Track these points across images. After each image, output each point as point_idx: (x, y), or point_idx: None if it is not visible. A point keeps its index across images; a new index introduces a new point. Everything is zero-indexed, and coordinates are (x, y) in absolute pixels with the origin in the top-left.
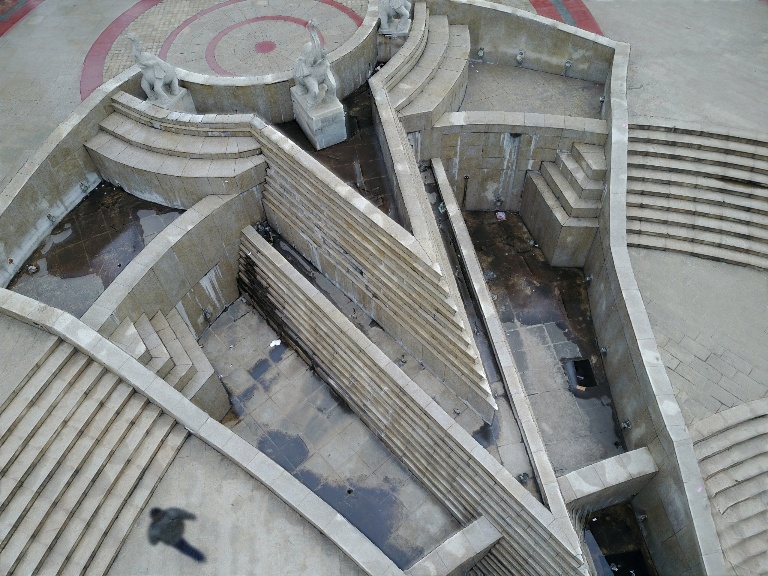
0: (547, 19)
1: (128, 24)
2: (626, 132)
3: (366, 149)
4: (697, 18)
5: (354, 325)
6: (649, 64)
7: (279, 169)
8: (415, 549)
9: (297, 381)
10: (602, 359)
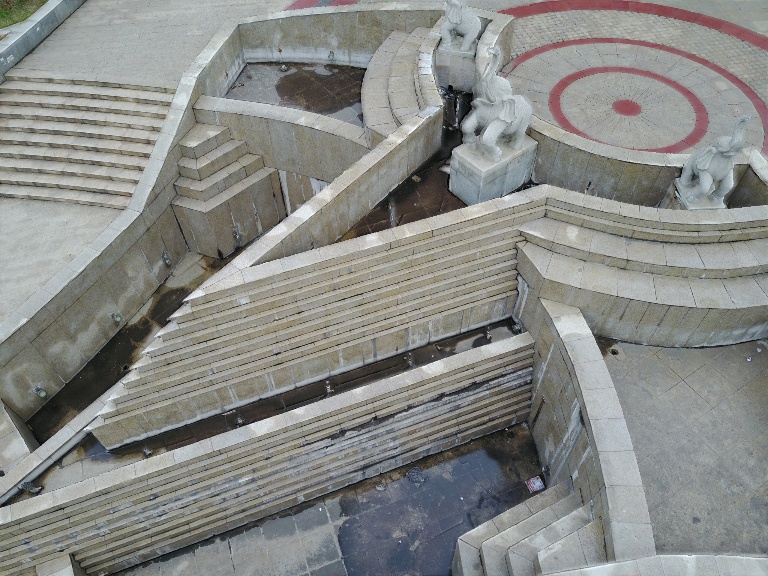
0: None
1: (611, 9)
2: None
3: None
4: None
5: None
6: None
7: None
8: None
9: None
10: None
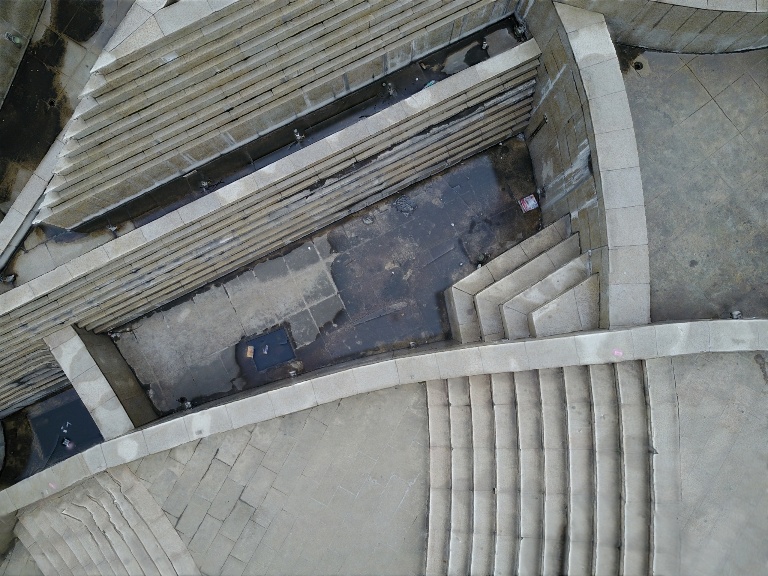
0: None
1: None
2: (605, 359)
3: None
4: None
5: None
6: None
7: None
8: (7, 191)
9: None
10: None
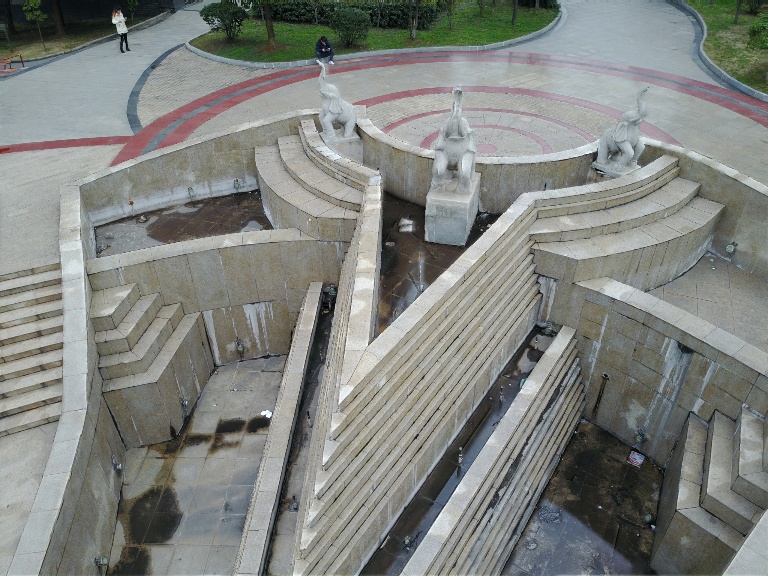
0: None
1: (402, 97)
2: None
3: None
4: None
5: None
6: None
7: None
8: None
9: (242, 462)
10: None
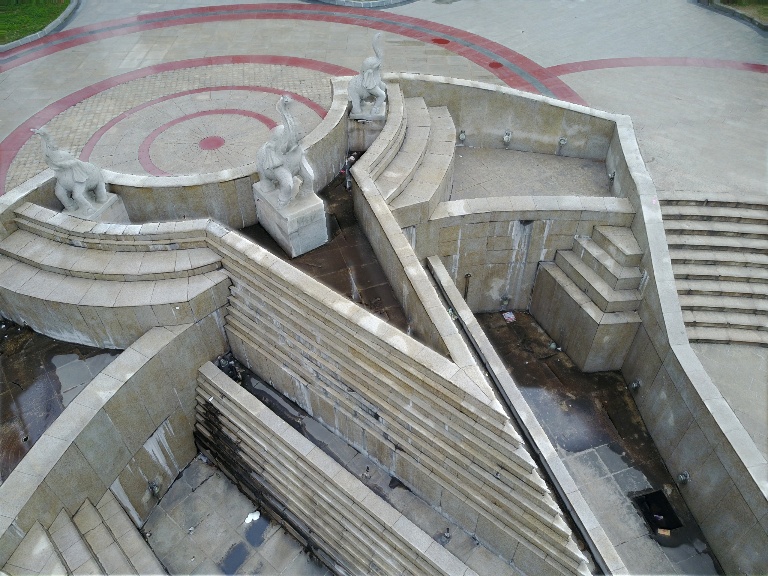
0: (535, 95)
1: (39, 127)
2: (658, 209)
3: (354, 252)
4: (684, 89)
5: (370, 489)
6: (653, 136)
7: (248, 286)
8: None
9: (289, 571)
10: (678, 488)
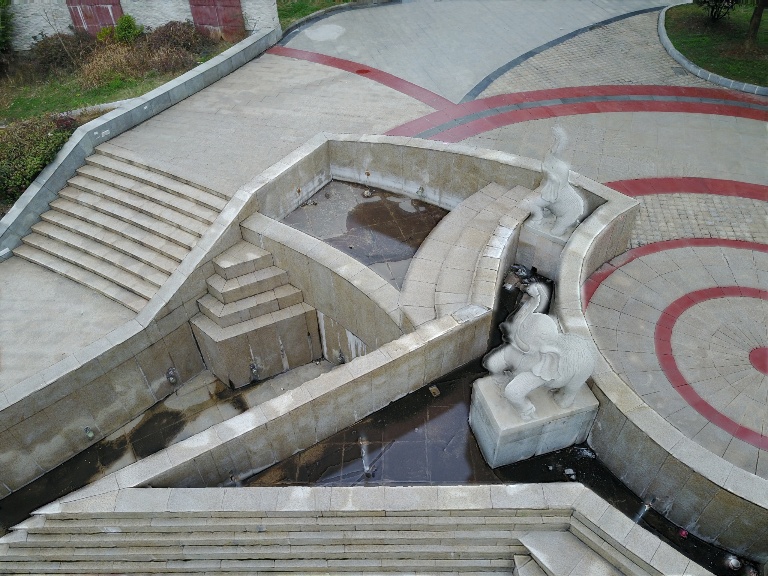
0: None
1: None
2: None
3: None
4: None
5: None
6: None
7: None
8: None
9: None
10: None
